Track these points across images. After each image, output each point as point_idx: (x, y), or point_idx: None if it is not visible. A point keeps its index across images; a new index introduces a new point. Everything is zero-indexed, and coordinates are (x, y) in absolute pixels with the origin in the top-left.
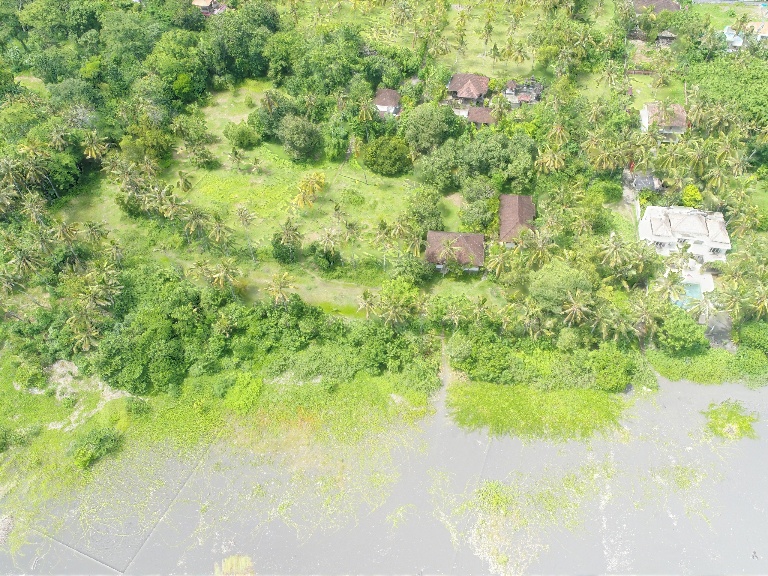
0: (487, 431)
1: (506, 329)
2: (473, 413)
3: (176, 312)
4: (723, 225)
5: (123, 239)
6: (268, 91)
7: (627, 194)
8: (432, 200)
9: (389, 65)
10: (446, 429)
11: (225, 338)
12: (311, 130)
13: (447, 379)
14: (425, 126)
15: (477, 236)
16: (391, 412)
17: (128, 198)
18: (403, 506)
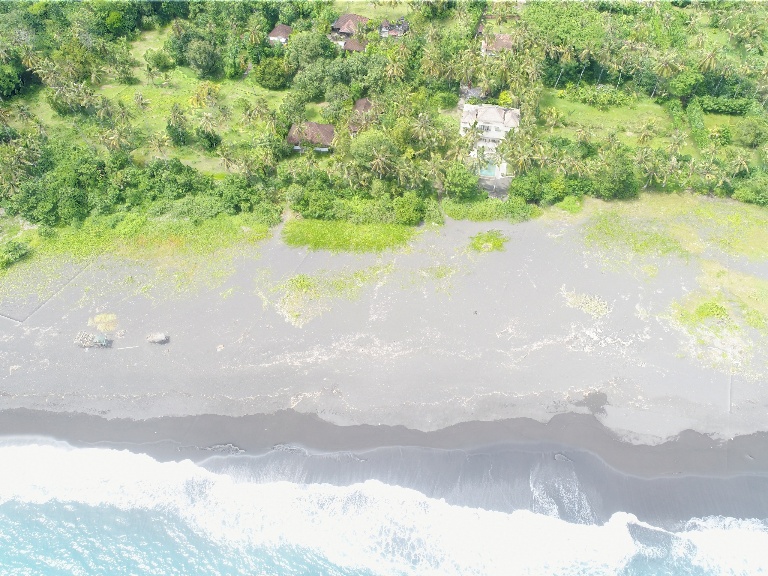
0: (307, 247)
1: (335, 183)
2: (300, 237)
3: (82, 168)
4: (515, 115)
5: (52, 130)
6: (178, 21)
7: (461, 103)
8: (299, 101)
9: (285, 6)
10: (277, 246)
11: (120, 189)
12: (212, 52)
13: (287, 218)
14: (303, 49)
15: (329, 125)
16: (239, 236)
17: (56, 97)
18: (233, 288)
